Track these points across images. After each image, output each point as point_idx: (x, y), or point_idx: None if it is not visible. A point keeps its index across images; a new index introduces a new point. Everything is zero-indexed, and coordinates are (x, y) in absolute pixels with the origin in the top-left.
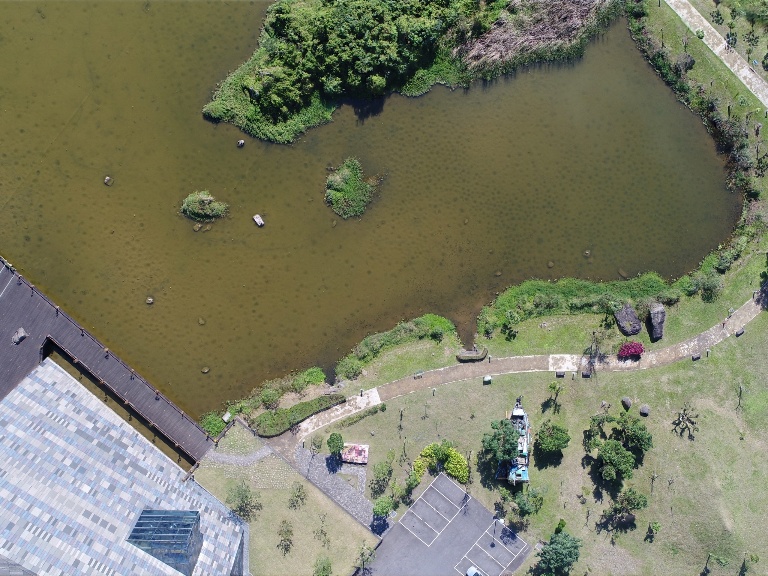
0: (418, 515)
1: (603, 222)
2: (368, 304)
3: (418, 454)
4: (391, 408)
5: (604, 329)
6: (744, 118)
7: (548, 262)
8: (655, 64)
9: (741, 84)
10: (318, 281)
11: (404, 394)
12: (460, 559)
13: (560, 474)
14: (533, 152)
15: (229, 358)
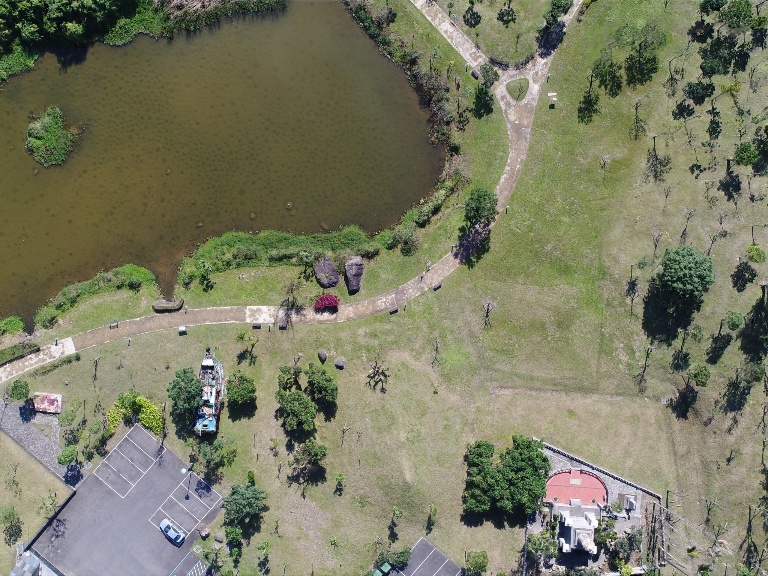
0: (113, 466)
1: (306, 174)
2: (69, 253)
3: (113, 404)
4: (86, 358)
5: None
6: (445, 72)
7: (250, 214)
8: (358, 17)
9: (442, 38)
10: (19, 229)
11: (99, 344)
12: (155, 511)
13: (253, 426)
14: (236, 103)
15: None
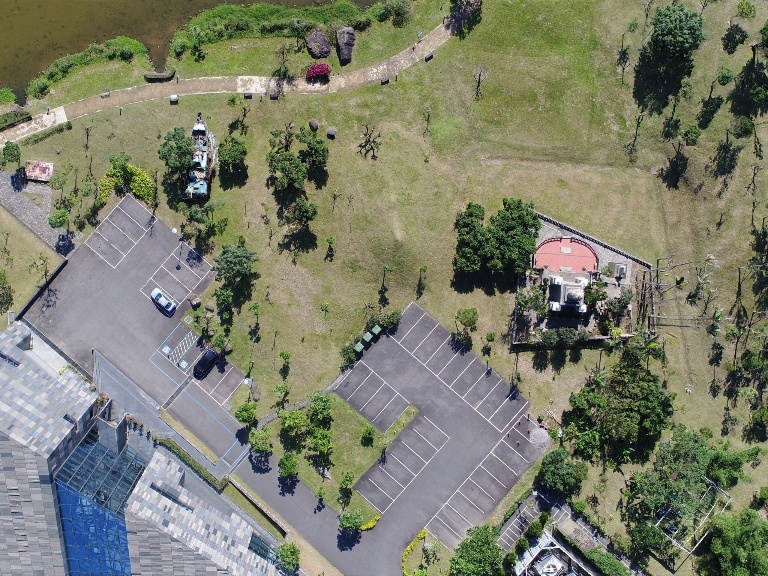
0: (104, 236)
1: None
2: (61, 26)
3: (104, 174)
4: (77, 127)
5: (294, 52)
6: None
7: None
8: None
9: None
10: (11, 2)
11: (91, 113)
12: (146, 282)
13: (245, 195)
14: None
15: None
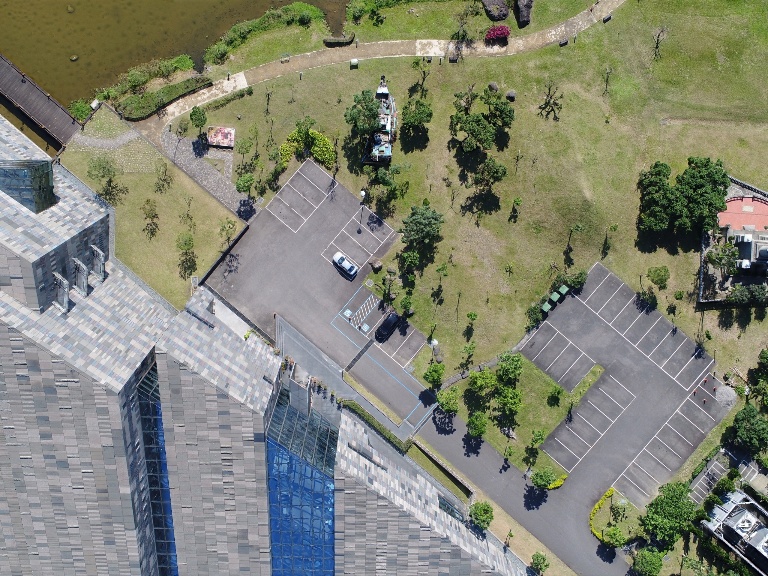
0: (285, 201)
1: None
2: None
3: (285, 139)
4: (258, 92)
5: None
6: None
7: None
8: None
9: None
10: None
11: (271, 78)
12: (327, 246)
13: (426, 158)
14: None
15: (98, 46)
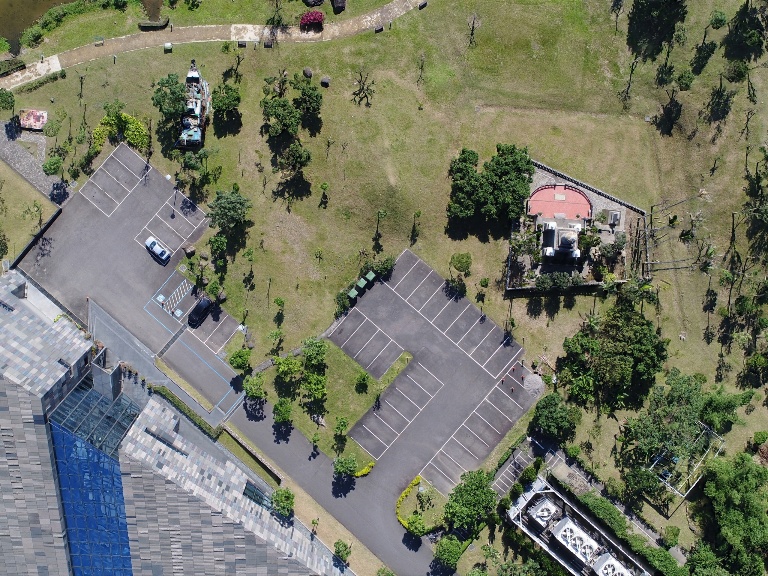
0: (98, 185)
1: None
2: None
3: (98, 122)
4: (71, 75)
5: (288, 0)
6: None
7: None
8: None
9: None
10: None
11: (85, 61)
12: (140, 230)
13: (239, 142)
14: None
15: None
